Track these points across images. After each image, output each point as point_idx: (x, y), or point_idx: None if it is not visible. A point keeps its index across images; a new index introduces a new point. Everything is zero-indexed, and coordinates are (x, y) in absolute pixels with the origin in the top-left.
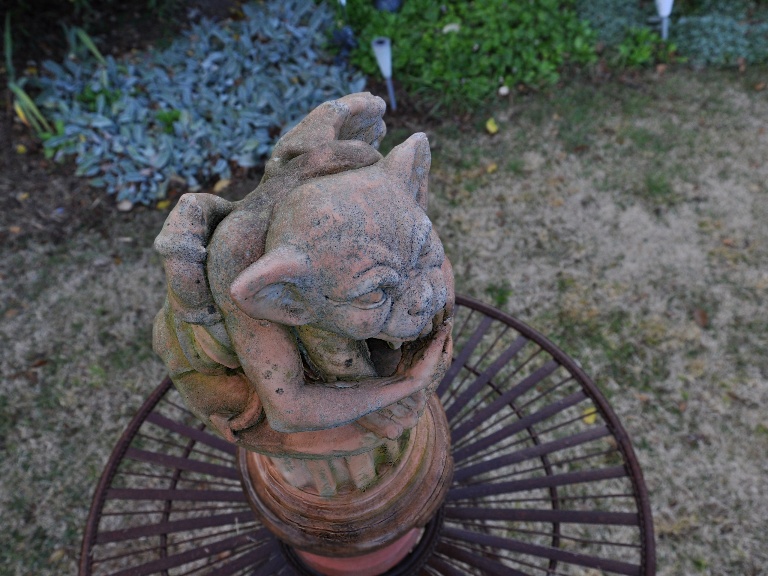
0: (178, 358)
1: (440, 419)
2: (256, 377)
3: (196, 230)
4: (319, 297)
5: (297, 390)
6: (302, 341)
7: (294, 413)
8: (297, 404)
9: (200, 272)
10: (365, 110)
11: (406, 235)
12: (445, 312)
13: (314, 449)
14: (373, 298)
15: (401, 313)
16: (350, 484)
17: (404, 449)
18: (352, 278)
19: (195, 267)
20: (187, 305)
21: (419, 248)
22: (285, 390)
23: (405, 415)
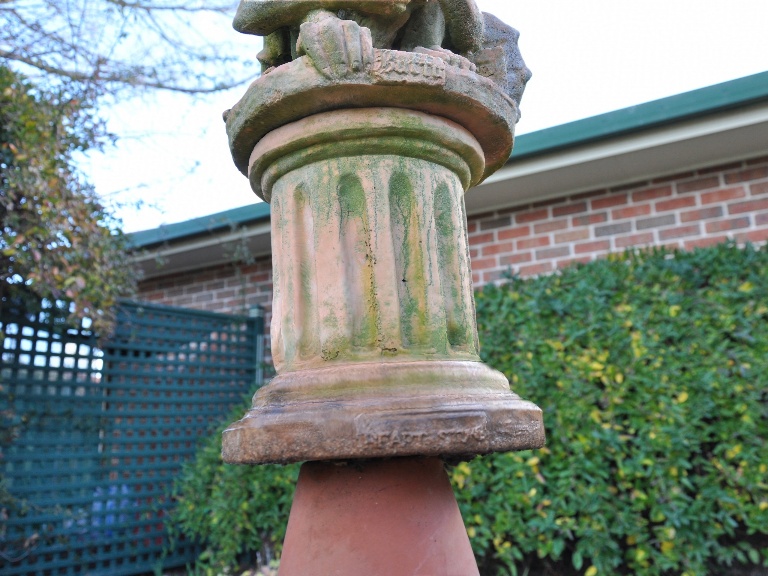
0: None
1: (508, 394)
2: None
3: None
4: None
5: None
6: None
7: None
8: None
9: None
10: (489, 17)
11: None
12: None
13: None
14: None
15: None
16: (316, 339)
17: (413, 352)
18: None
19: None
20: None
21: None
22: None
23: None
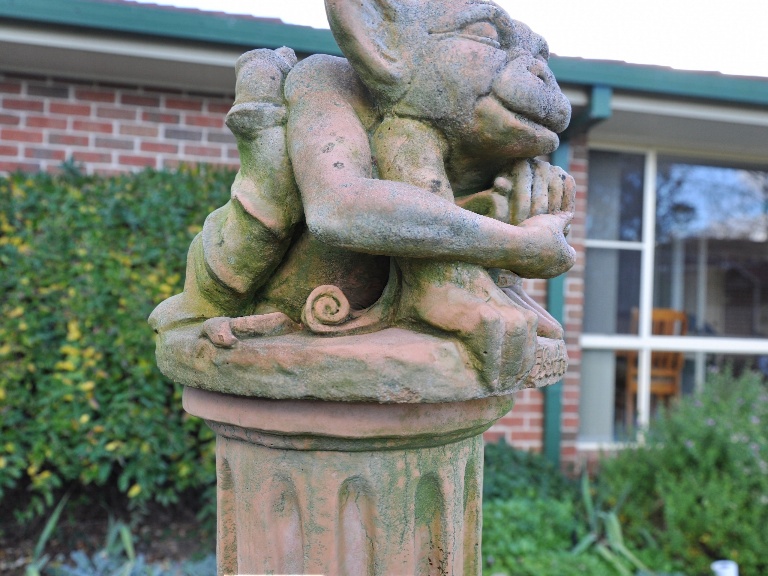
0: (182, 302)
1: None
2: (309, 159)
3: (286, 60)
4: (421, 32)
5: (362, 176)
6: (377, 157)
7: (353, 186)
8: (359, 179)
9: (279, 74)
10: None
11: (523, 24)
12: (563, 197)
13: (355, 346)
14: (486, 30)
15: (518, 64)
16: None
17: None
18: (464, 4)
19: (275, 68)
20: (251, 96)
21: (538, 39)
22: (346, 166)
23: (509, 305)
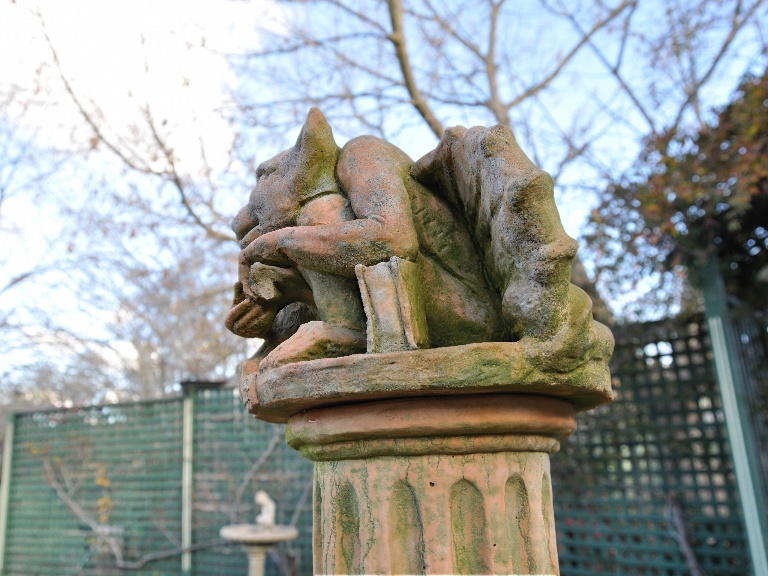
0: None
1: None
2: None
3: None
4: None
5: None
6: None
7: None
8: None
9: None
10: None
11: None
12: None
13: None
14: None
15: None
16: None
17: None
18: None
19: None
20: None
21: None
22: None
23: None
